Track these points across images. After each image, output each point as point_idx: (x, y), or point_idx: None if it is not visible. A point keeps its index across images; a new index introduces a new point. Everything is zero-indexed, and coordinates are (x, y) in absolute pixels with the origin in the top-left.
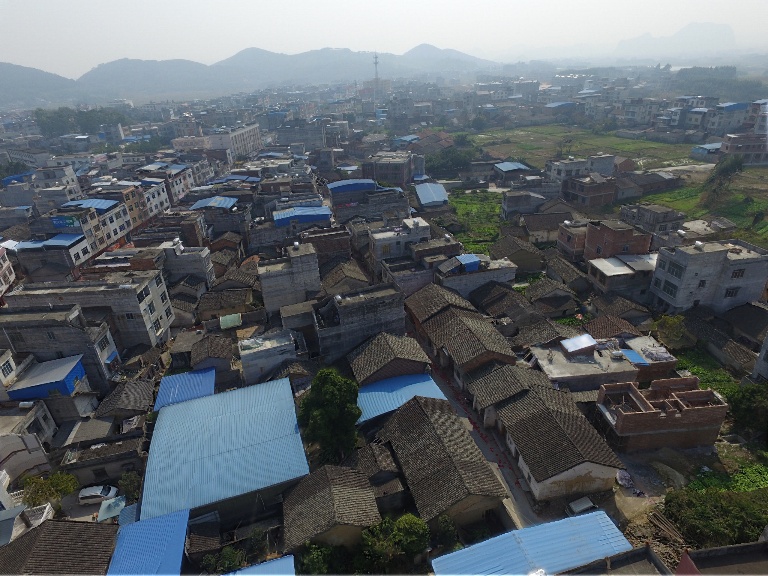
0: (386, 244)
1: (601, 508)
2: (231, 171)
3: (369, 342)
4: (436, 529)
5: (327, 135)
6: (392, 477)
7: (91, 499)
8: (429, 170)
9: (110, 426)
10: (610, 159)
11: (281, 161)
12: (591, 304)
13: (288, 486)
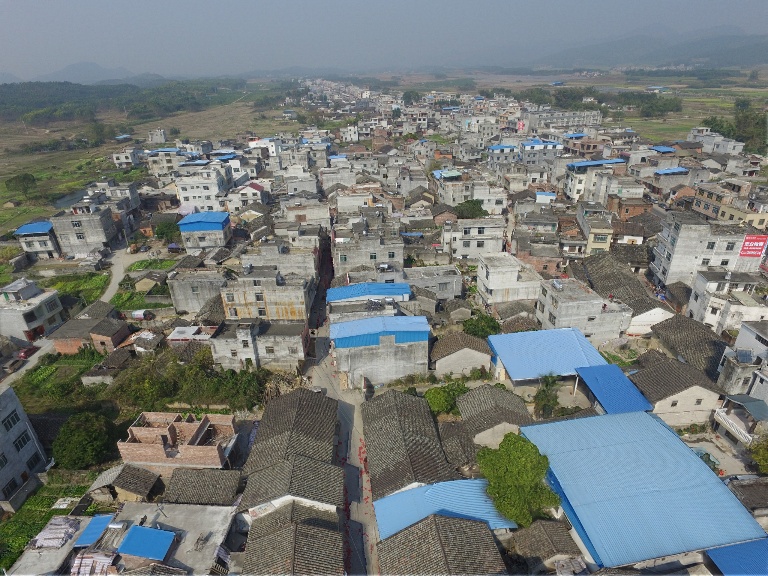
0: None
1: None
2: None
3: None
4: None
5: None
6: None
7: None
8: None
9: None
10: None
11: None
12: None
13: None
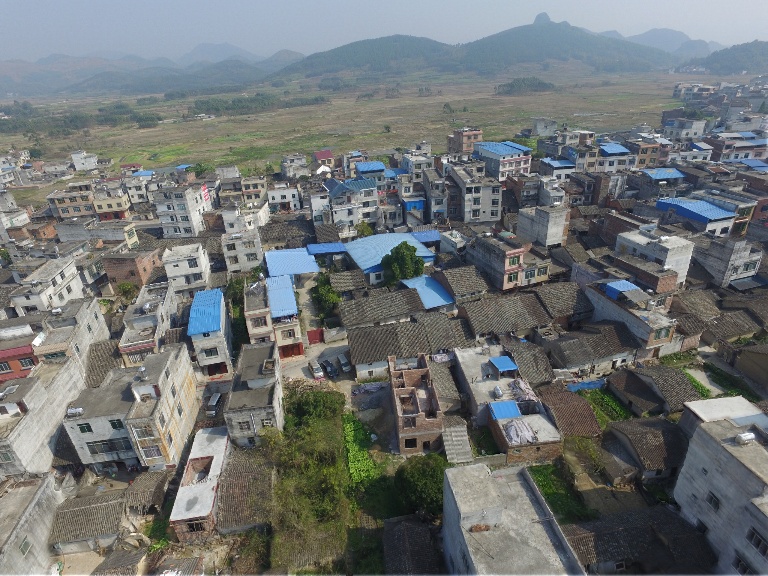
0: (625, 245)
1: (346, 374)
2: None
3: None
4: None
5: None
6: None
7: None
8: None
9: (404, 232)
10: None
11: None
12: None
13: None
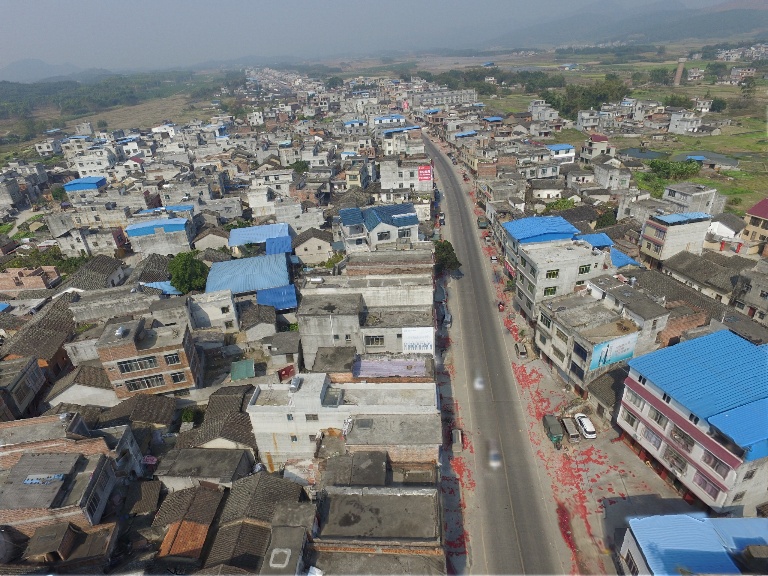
0: None
1: None
2: None
3: None
4: None
5: None
6: None
7: None
8: None
9: None
10: None
11: None
12: None
13: None
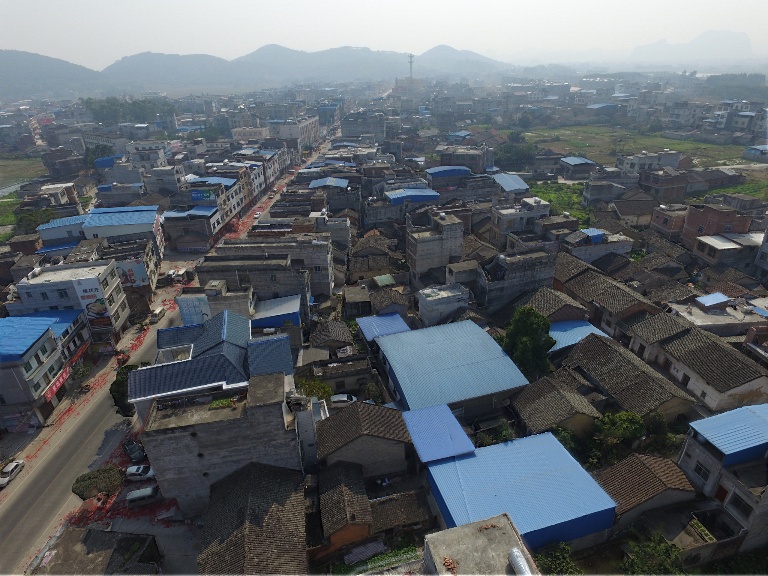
0: (511, 219)
1: None
2: (325, 157)
3: (533, 294)
4: (649, 422)
5: (386, 128)
6: (589, 391)
7: (340, 403)
8: (496, 163)
9: None
10: (676, 155)
11: (367, 149)
12: (701, 274)
13: (513, 393)
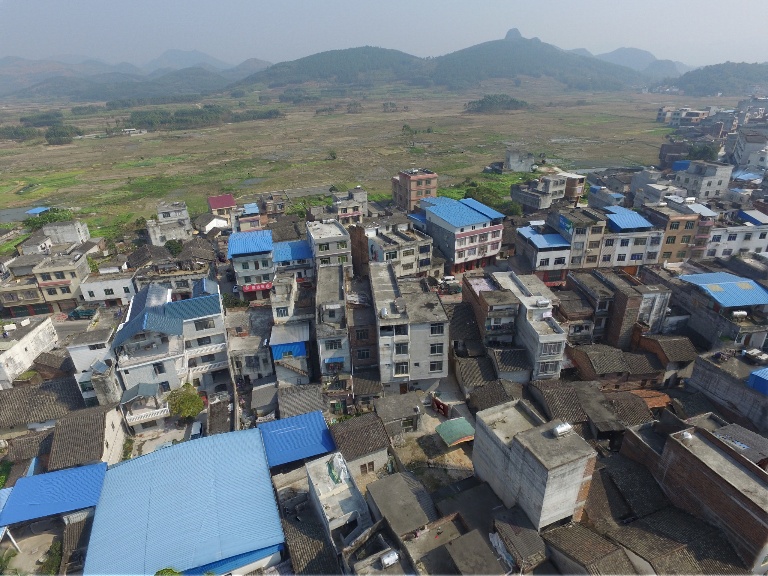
0: None
1: None
2: None
3: None
4: None
5: None
6: None
7: None
8: None
9: (266, 404)
10: None
11: None
12: None
13: None
